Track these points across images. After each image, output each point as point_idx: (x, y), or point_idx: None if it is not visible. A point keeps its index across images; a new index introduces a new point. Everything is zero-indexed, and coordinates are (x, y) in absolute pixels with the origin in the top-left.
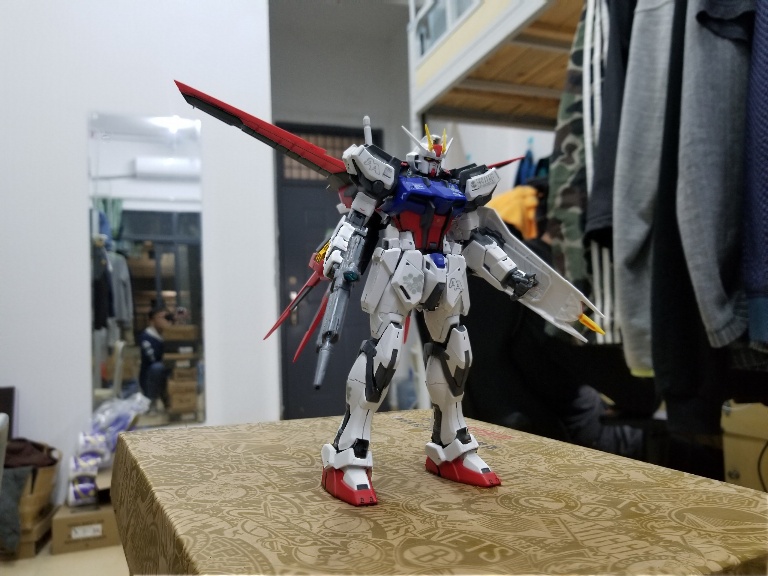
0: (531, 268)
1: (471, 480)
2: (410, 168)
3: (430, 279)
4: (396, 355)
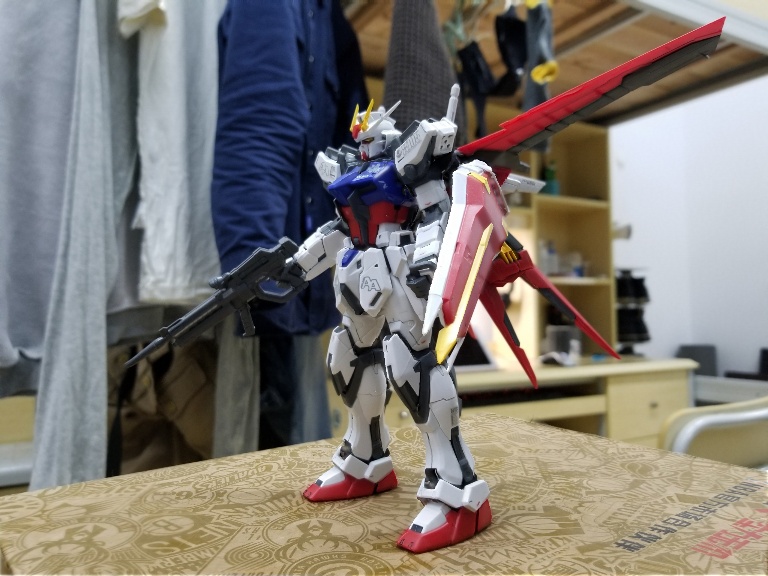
0: None
1: None
2: None
3: None
4: (330, 360)
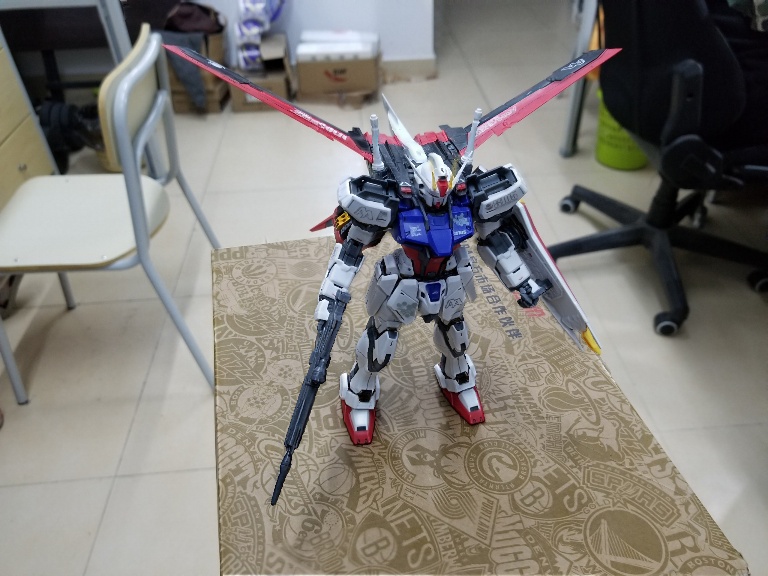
0: None
1: (461, 412)
2: (415, 193)
3: (424, 307)
4: (389, 358)
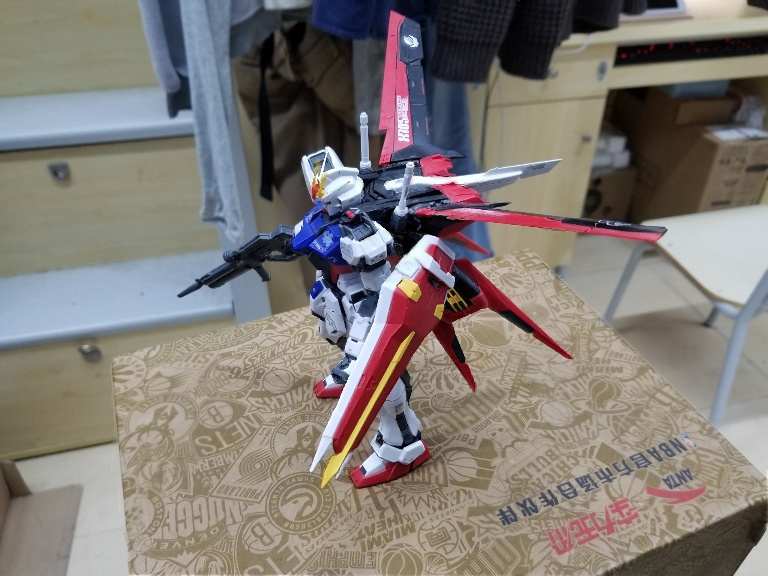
0: None
1: None
2: None
3: None
4: None
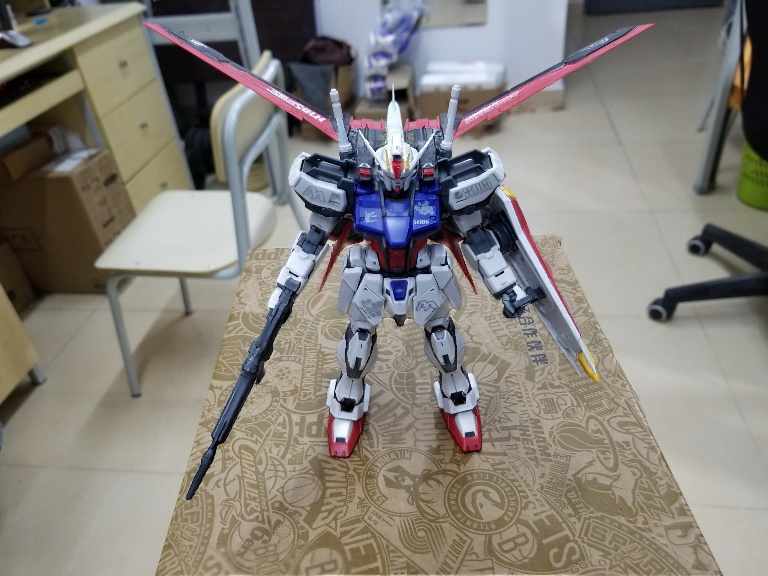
0: (538, 280)
1: (456, 437)
2: (375, 176)
3: (390, 306)
4: (360, 362)
